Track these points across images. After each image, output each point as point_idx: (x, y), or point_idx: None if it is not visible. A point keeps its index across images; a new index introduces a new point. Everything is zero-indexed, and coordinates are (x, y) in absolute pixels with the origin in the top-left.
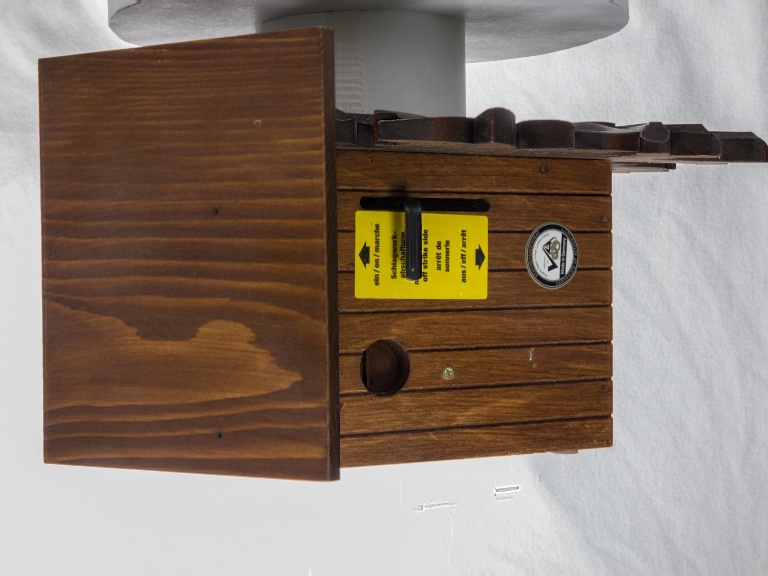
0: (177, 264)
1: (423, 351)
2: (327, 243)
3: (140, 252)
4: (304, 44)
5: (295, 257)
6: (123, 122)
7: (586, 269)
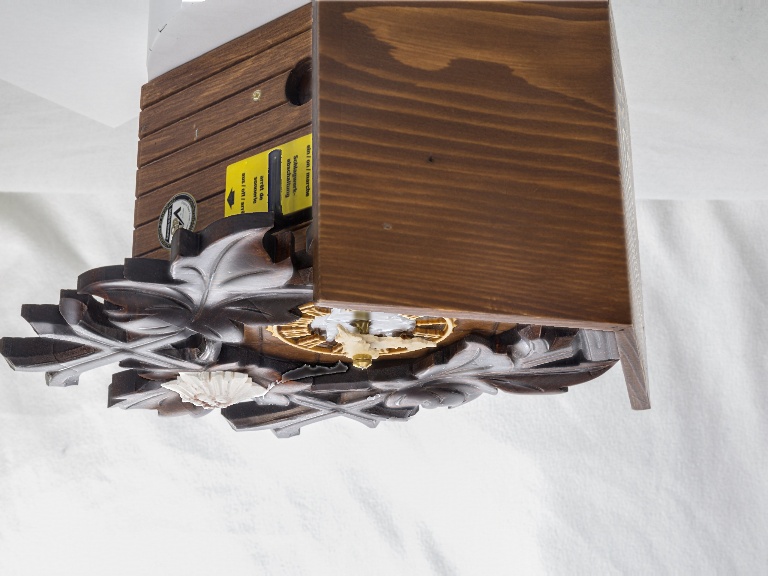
0: (471, 121)
1: (276, 106)
2: (318, 118)
3: (511, 137)
4: (338, 287)
5: (349, 110)
6: (533, 251)
7: (153, 220)
